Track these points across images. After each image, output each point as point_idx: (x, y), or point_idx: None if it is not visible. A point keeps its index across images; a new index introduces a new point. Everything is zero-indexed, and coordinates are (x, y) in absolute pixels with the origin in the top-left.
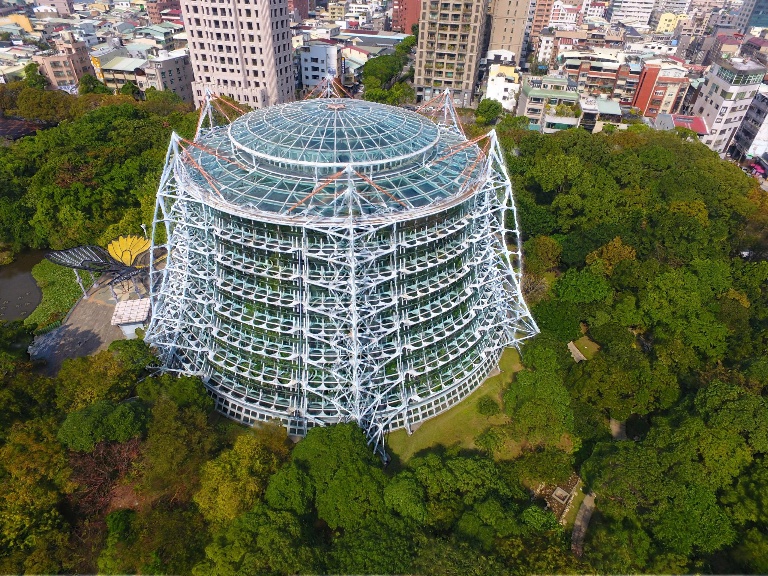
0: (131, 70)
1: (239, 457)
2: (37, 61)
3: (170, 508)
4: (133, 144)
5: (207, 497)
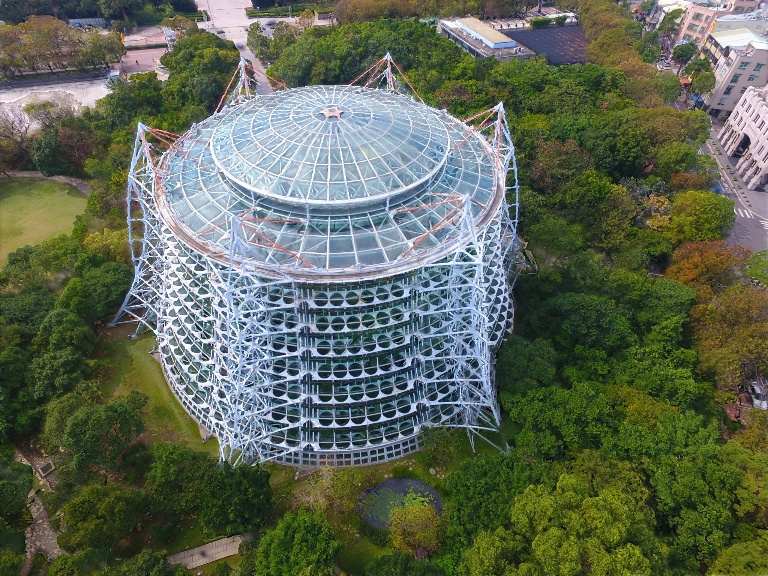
0: (724, 46)
1: (124, 239)
2: (688, 8)
3: (115, 227)
4: (538, 103)
5: (105, 234)
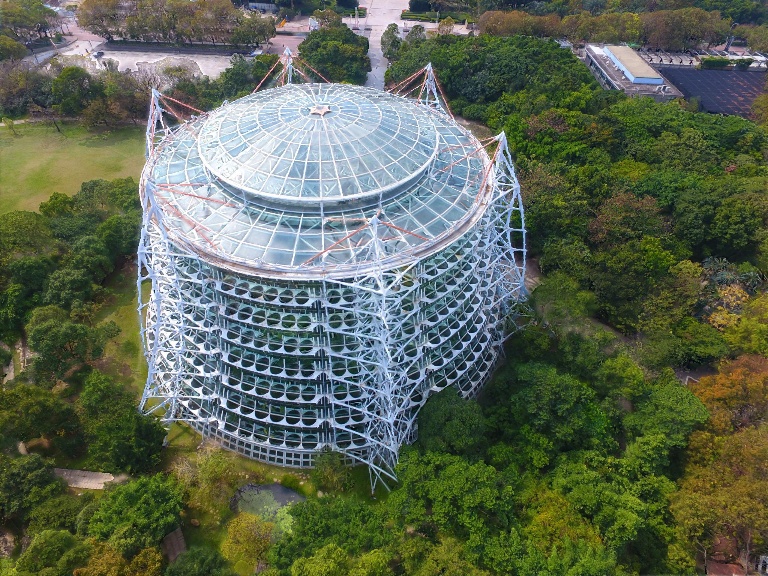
0: None
1: None
2: None
3: None
4: (645, 149)
5: None
